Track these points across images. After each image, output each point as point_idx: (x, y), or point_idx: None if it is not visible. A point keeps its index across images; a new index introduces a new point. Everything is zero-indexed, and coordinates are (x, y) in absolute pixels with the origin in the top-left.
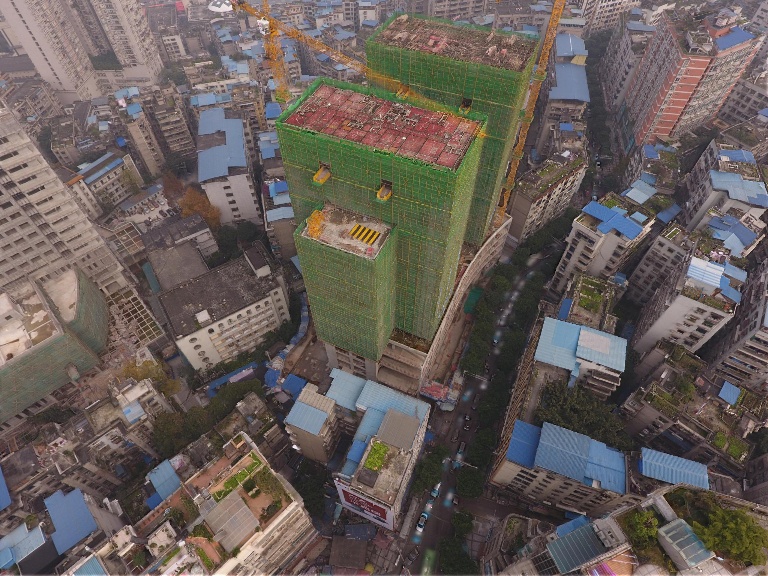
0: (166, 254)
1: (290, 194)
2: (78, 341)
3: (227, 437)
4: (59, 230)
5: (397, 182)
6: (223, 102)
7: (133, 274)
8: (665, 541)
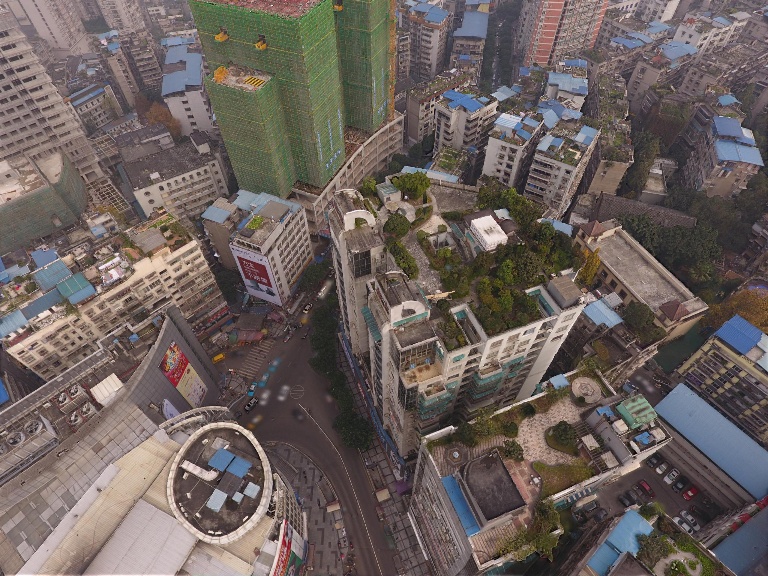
0: (134, 149)
1: (207, 61)
2: None
3: None
4: (47, 116)
5: (267, 35)
6: (188, 43)
7: (108, 168)
8: (378, 191)
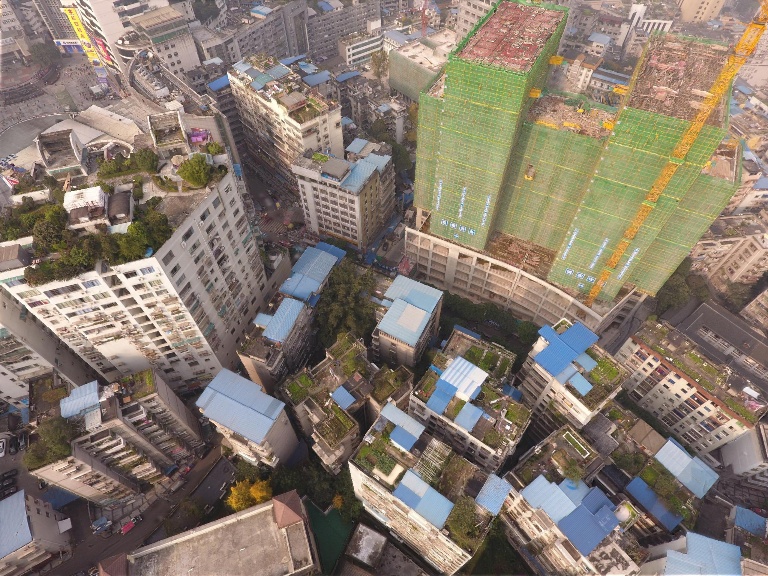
0: None
1: None
2: None
3: None
4: None
5: None
6: None
7: None
8: None
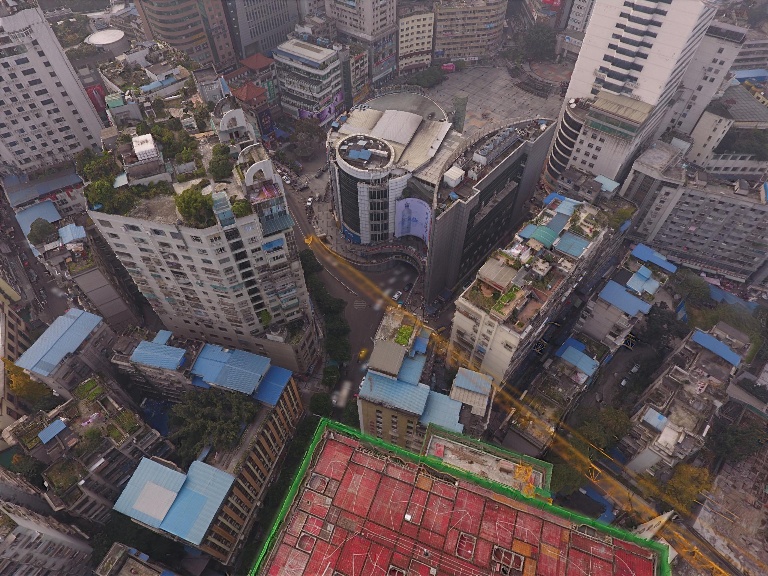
0: None
1: None
2: None
3: (549, 403)
4: None
5: None
6: None
7: None
8: None
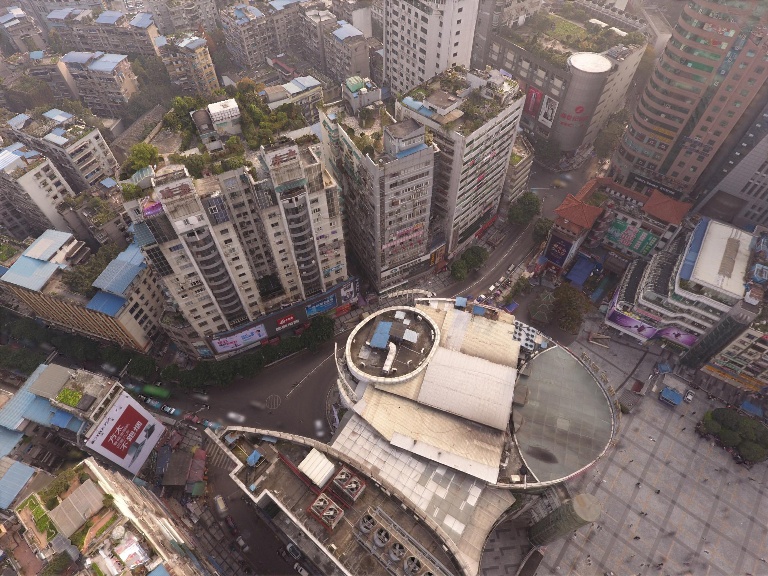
0: None
1: None
2: None
3: None
4: None
5: None
6: None
7: None
8: (141, 184)
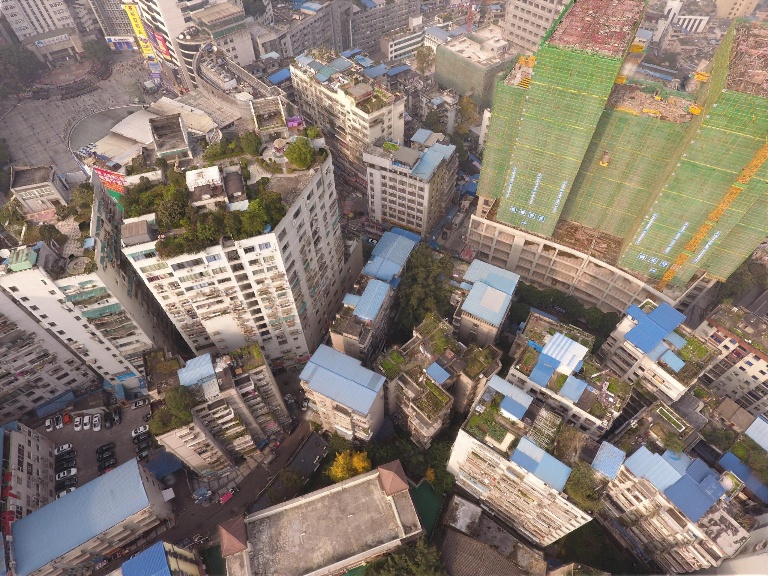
0: None
1: None
2: (486, 82)
3: None
4: None
5: None
6: None
7: None
8: None
